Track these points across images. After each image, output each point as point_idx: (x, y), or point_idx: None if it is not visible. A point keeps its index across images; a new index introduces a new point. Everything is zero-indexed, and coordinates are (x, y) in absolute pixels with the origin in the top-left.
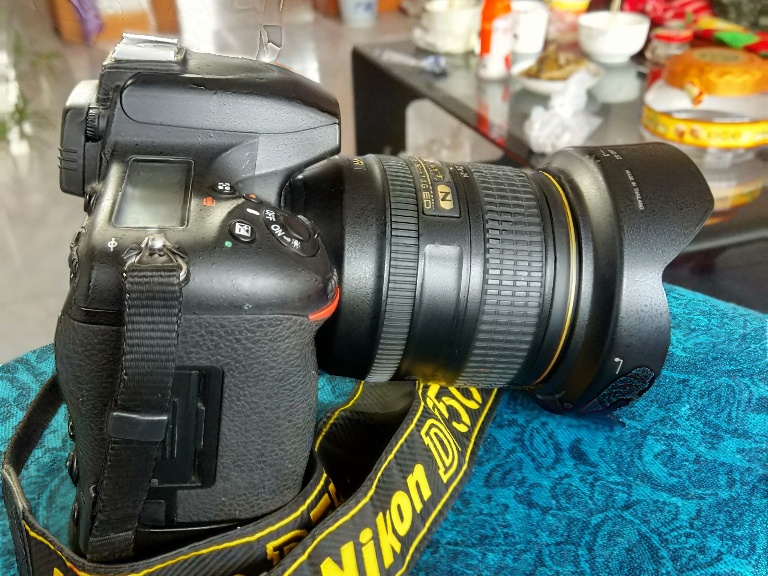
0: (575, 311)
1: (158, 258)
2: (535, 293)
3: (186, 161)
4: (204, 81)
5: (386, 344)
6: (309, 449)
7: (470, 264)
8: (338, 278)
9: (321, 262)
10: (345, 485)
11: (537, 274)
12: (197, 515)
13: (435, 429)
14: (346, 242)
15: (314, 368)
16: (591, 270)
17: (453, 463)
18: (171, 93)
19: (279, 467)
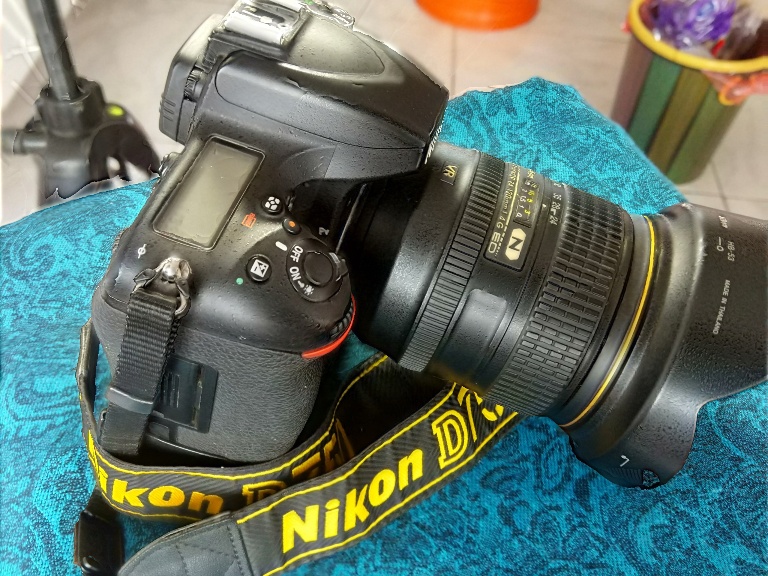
0: (603, 397)
1: (168, 285)
2: (567, 368)
3: (259, 153)
4: (300, 75)
5: (411, 354)
6: (299, 430)
7: (511, 320)
8: (380, 289)
9: (333, 307)
10: (357, 433)
11: (576, 352)
12: (194, 445)
13: (452, 420)
14: (398, 259)
15: (308, 383)
16: (635, 368)
17: (458, 453)
18: (263, 82)
19: (265, 439)
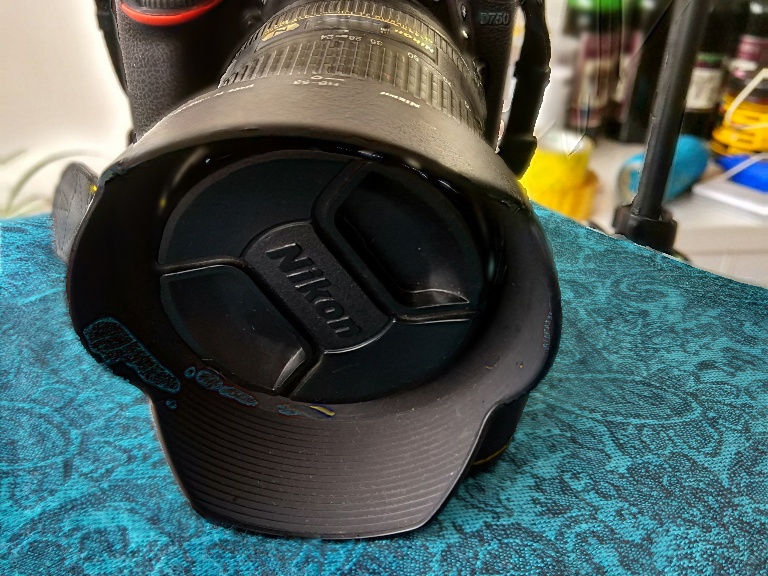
0: None
1: None
2: None
3: None
4: None
5: None
6: None
7: None
8: None
9: None
10: None
11: None
12: None
13: None
14: None
15: (138, 64)
16: None
17: None
18: None
19: None
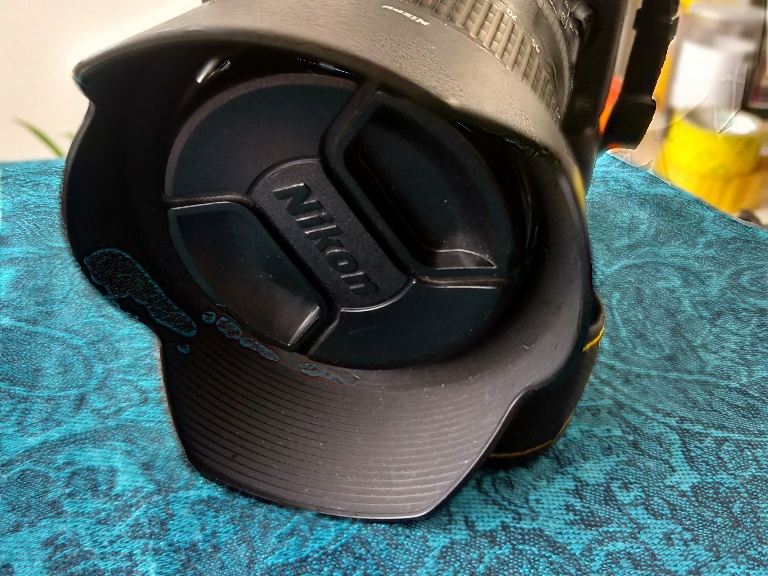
0: None
1: None
2: None
3: None
4: None
5: None
6: None
7: None
8: None
9: None
10: None
11: None
12: None
13: None
14: None
15: None
16: None
17: None
18: None
19: None
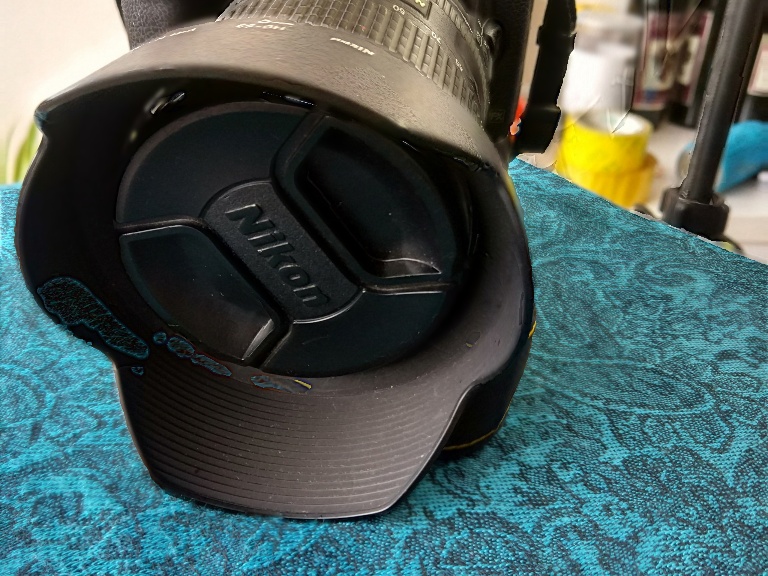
0: None
1: None
2: None
3: None
4: None
5: None
6: None
7: None
8: None
9: None
10: None
11: None
12: None
13: None
14: None
15: (137, 23)
16: None
17: None
18: None
19: None
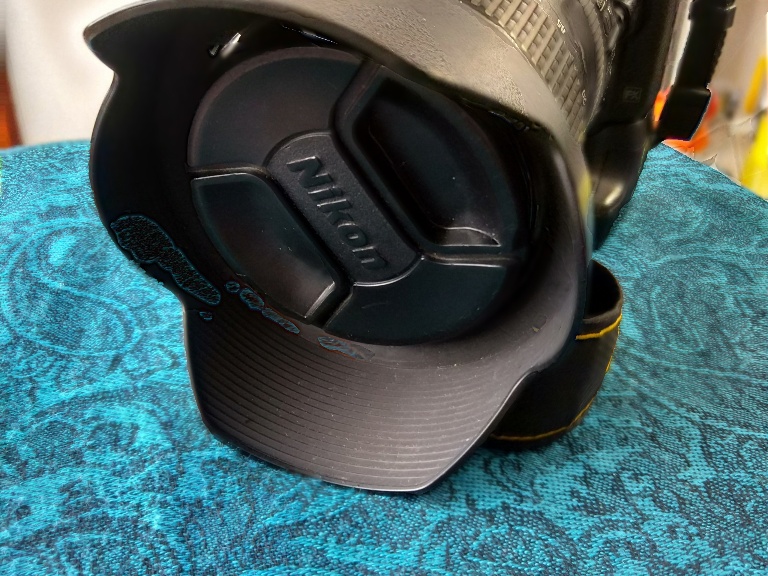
0: None
1: None
2: None
3: None
4: None
5: None
6: None
7: None
8: None
9: None
10: None
11: None
12: None
13: None
14: None
15: None
16: None
17: None
18: None
19: None
